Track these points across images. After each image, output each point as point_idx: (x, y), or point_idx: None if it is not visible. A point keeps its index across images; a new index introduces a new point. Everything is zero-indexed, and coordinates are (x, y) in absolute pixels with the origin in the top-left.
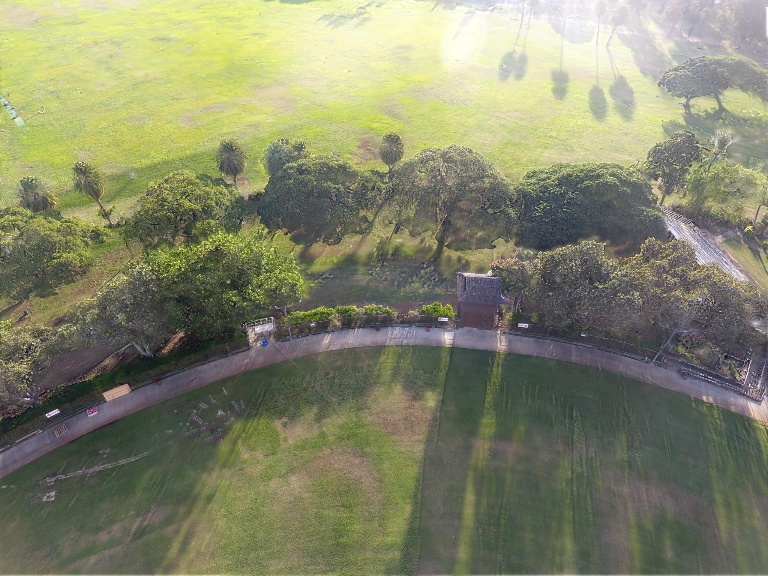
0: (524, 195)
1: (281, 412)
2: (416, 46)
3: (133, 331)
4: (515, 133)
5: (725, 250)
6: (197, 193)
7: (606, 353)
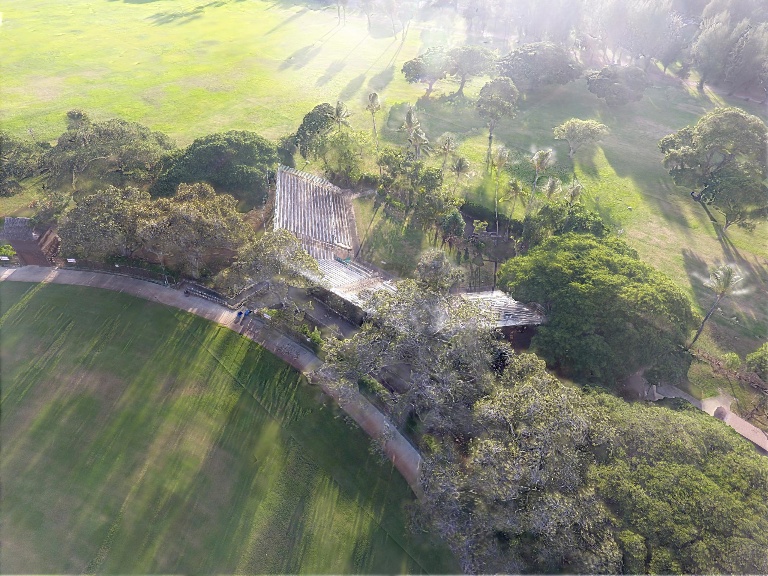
0: (164, 160)
1: None
2: (223, 41)
3: None
4: (252, 115)
5: (352, 205)
6: None
7: (137, 280)
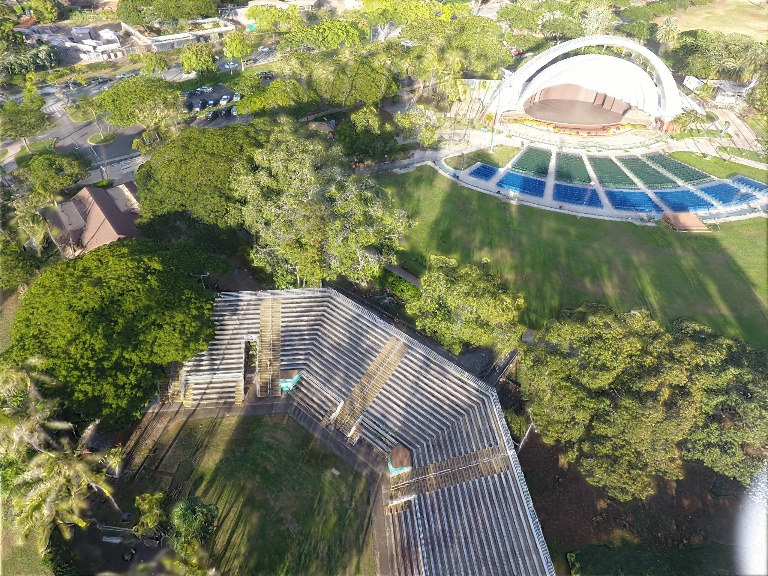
0: None
1: None
2: None
3: None
4: None
5: None
6: None
7: None
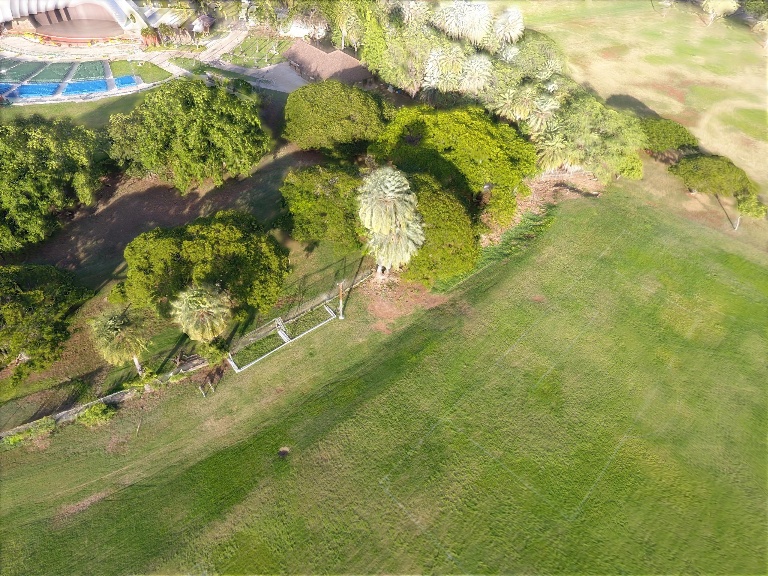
0: None
1: None
2: None
3: None
4: None
5: None
6: None
7: None
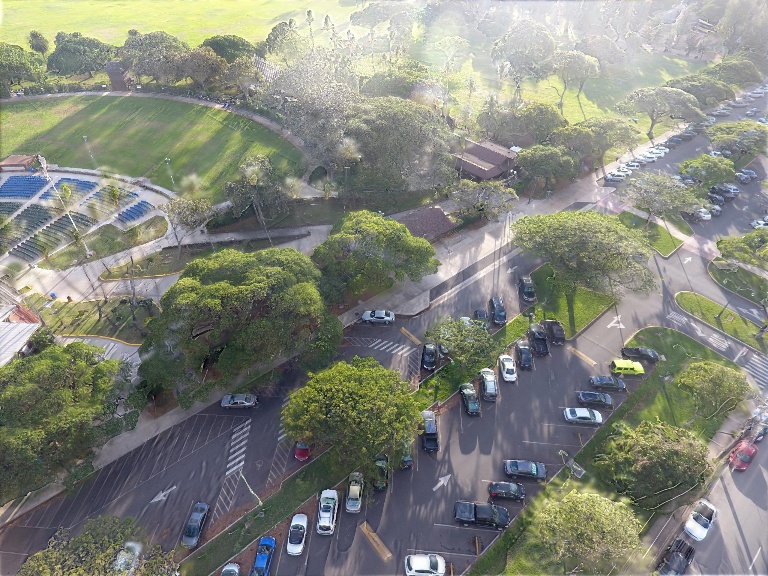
0: None
1: (14, 111)
2: (228, 9)
3: None
4: None
5: None
6: None
7: None
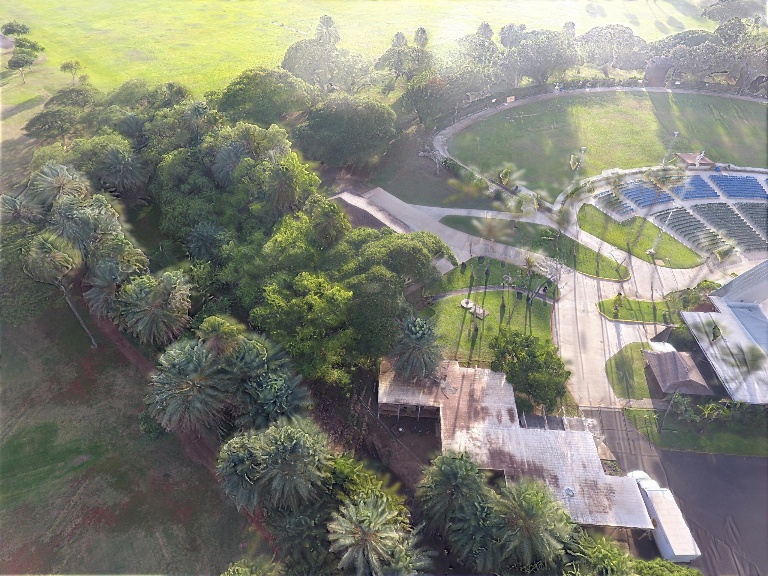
0: (654, 47)
1: (584, 106)
2: (521, 1)
3: (532, 62)
4: None
5: None
6: (489, 41)
7: (717, 93)
